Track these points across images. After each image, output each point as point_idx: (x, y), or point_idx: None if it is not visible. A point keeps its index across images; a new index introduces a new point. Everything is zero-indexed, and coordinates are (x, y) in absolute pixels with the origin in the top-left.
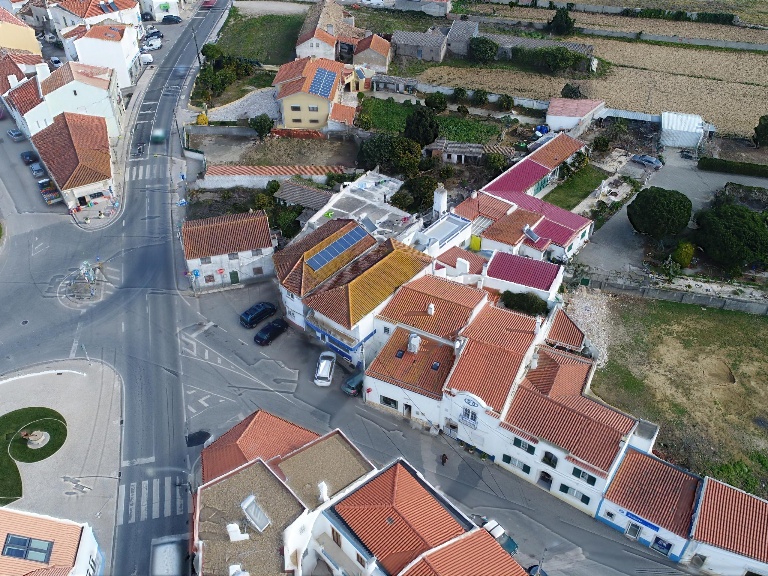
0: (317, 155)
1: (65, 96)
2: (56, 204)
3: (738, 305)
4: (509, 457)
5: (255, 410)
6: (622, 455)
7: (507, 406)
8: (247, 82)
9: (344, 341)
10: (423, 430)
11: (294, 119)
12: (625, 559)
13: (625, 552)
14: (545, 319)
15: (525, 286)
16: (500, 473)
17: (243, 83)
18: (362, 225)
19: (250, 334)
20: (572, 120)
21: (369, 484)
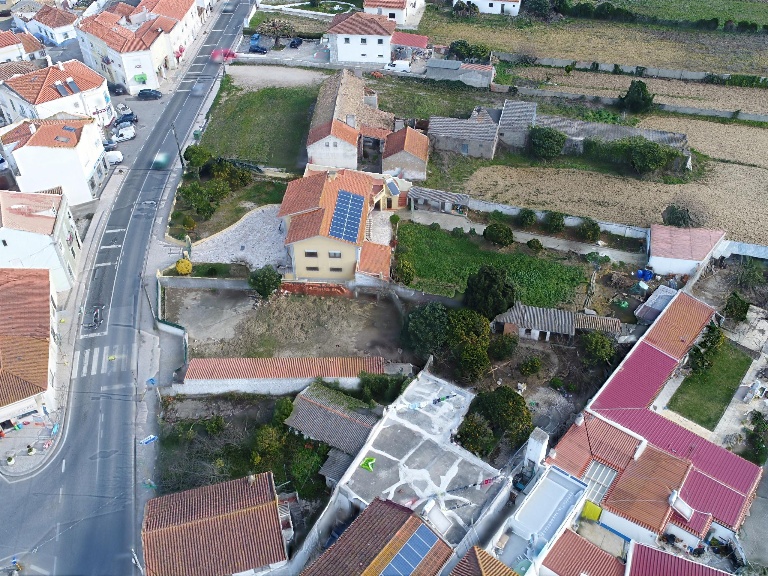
0: (342, 327)
1: None
2: None
3: None
4: None
5: None
6: None
7: None
8: (244, 195)
9: None
10: None
11: (308, 267)
12: None
13: None
14: None
15: None
16: None
17: (238, 197)
18: (428, 522)
19: None
20: (687, 264)
21: None
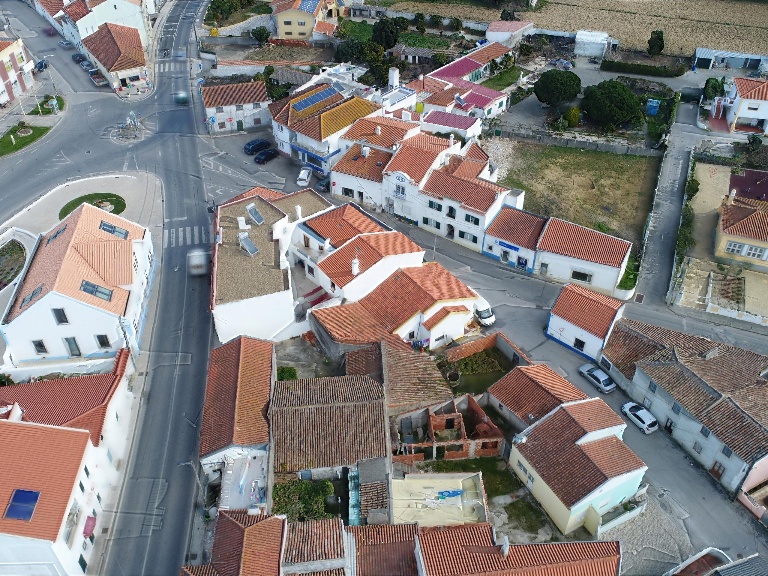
0: (304, 57)
1: (108, 9)
2: (103, 86)
3: (607, 147)
4: (427, 218)
5: None
6: (499, 209)
7: (425, 181)
8: (249, 10)
9: (318, 153)
10: (371, 210)
11: (286, 32)
12: (498, 272)
13: (499, 269)
14: (459, 141)
15: (450, 127)
16: (422, 232)
17: (246, 11)
18: (334, 86)
19: (251, 158)
20: (506, 35)
21: (329, 213)
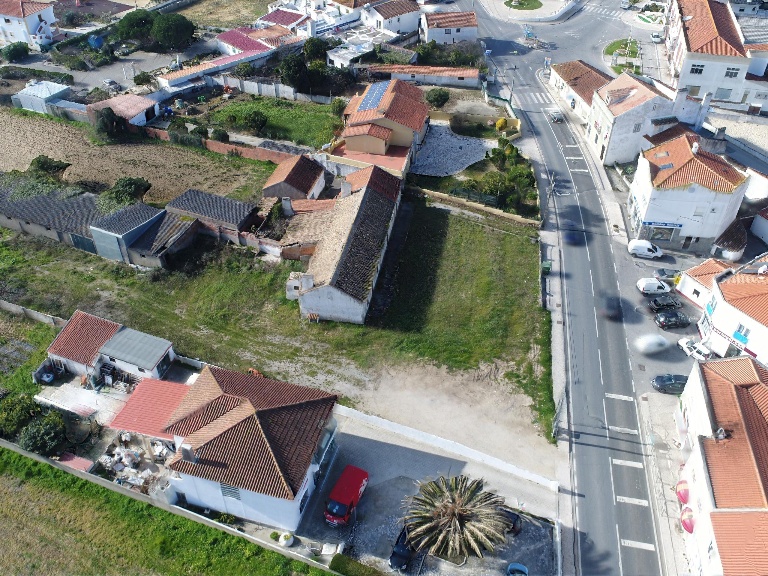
0: None
1: None
2: None
3: None
4: None
5: None
6: None
7: None
8: None
9: None
10: None
11: None
12: None
13: None
14: None
15: (288, 9)
16: None
17: None
18: None
19: None
20: None
21: None
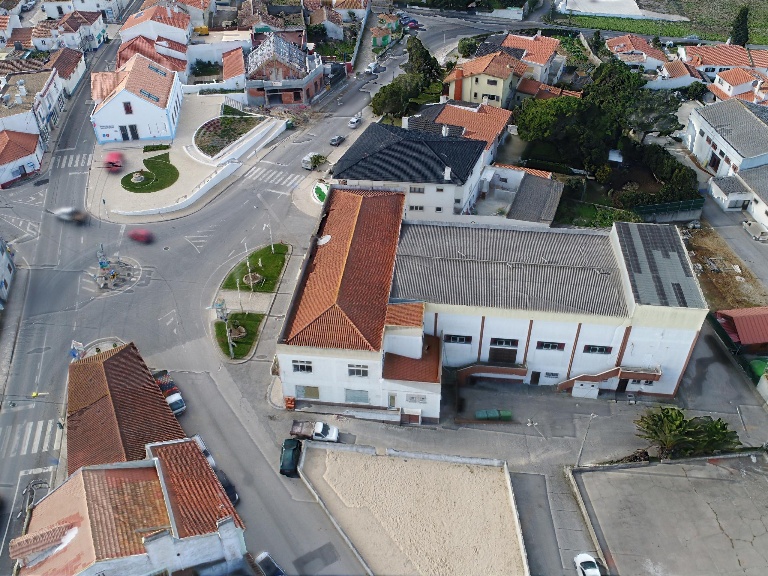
0: None
1: None
2: None
3: None
4: None
5: (1, 198)
6: None
7: None
8: None
9: None
10: None
11: None
12: None
13: None
14: None
15: None
16: None
17: None
18: None
19: None
20: None
21: None
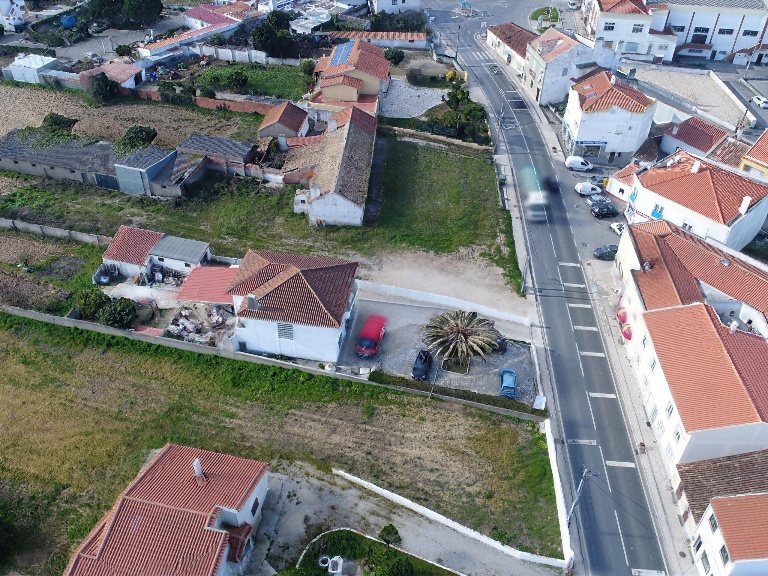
0: None
1: None
2: None
3: None
4: None
5: None
6: None
7: None
8: None
9: None
10: None
11: None
12: None
13: None
14: None
15: None
16: None
17: None
18: None
19: None
20: None
21: None
